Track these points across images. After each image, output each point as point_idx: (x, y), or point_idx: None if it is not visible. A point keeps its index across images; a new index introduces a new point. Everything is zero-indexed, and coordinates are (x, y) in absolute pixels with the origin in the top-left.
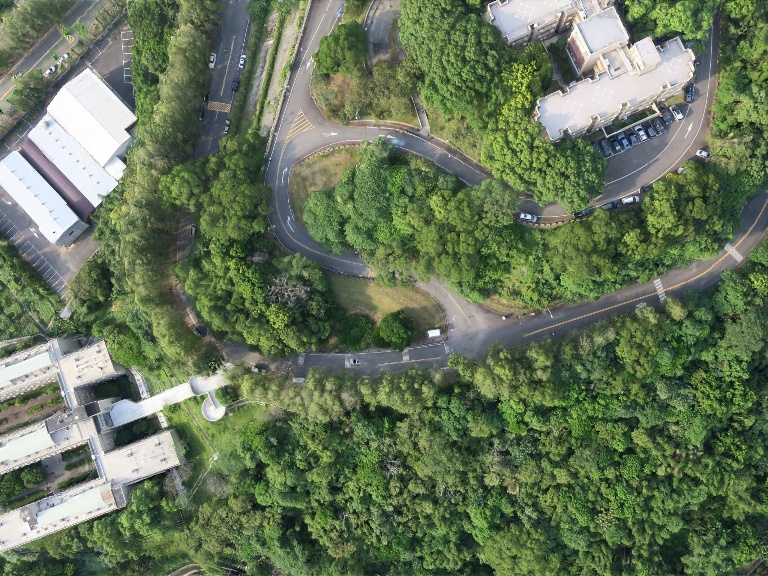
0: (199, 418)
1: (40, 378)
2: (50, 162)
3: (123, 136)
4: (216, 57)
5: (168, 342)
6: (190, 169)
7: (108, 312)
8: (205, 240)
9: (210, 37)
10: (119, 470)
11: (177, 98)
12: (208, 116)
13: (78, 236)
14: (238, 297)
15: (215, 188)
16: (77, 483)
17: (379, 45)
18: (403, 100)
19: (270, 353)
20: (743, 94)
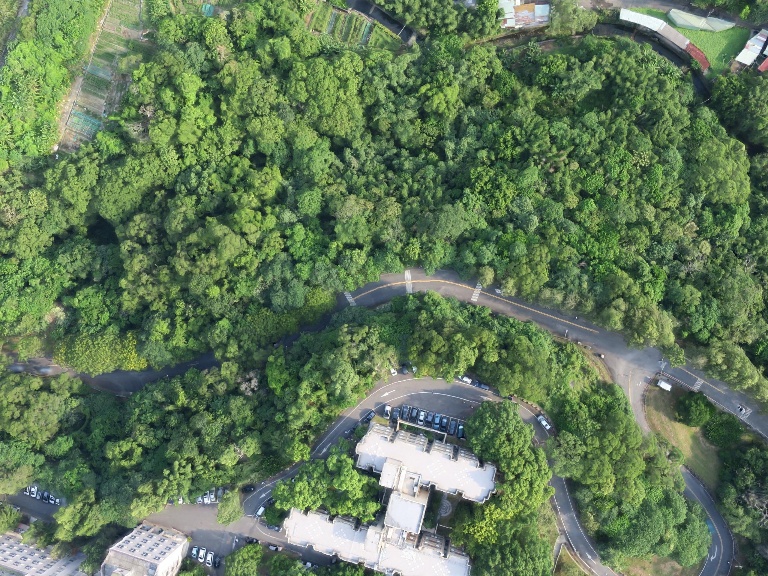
0: None
1: None
2: None
3: None
4: None
5: None
6: None
7: None
8: None
9: None
10: None
11: None
12: None
13: None
14: None
15: None
16: None
17: None
18: None
19: None
20: None
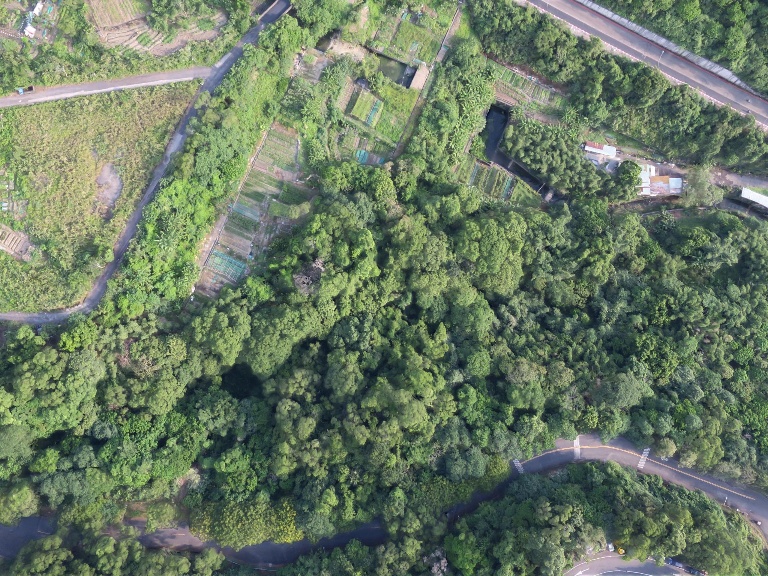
0: None
1: None
2: None
3: None
4: None
5: None
6: None
7: None
8: None
9: None
10: None
11: None
12: None
13: None
14: None
15: None
16: None
17: None
18: None
19: None
20: None
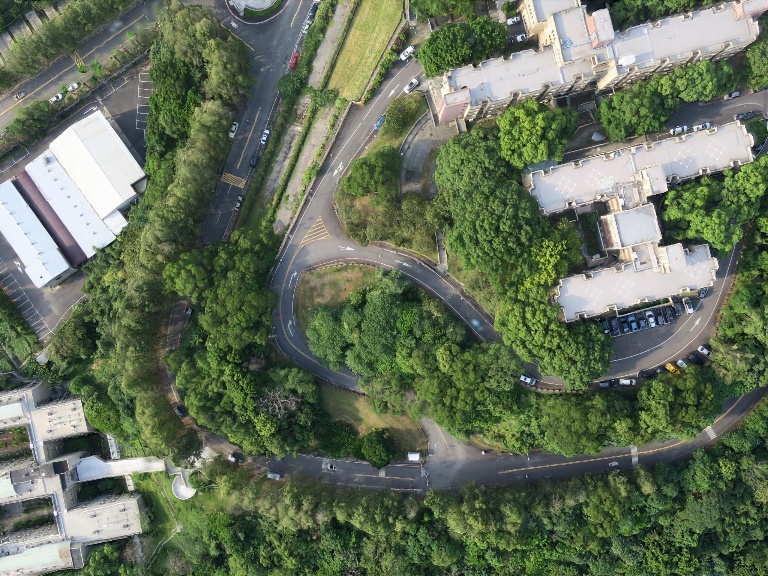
0: (168, 491)
1: (9, 426)
2: (45, 201)
3: (128, 192)
4: (238, 126)
5: (151, 433)
6: (197, 258)
7: (88, 369)
8: (202, 330)
9: (236, 109)
10: (80, 529)
11: (194, 180)
12: (221, 188)
13: (65, 278)
14: (228, 401)
15: (222, 291)
16: (34, 528)
17: (412, 173)
18: (427, 239)
19: (251, 454)
20: (755, 312)
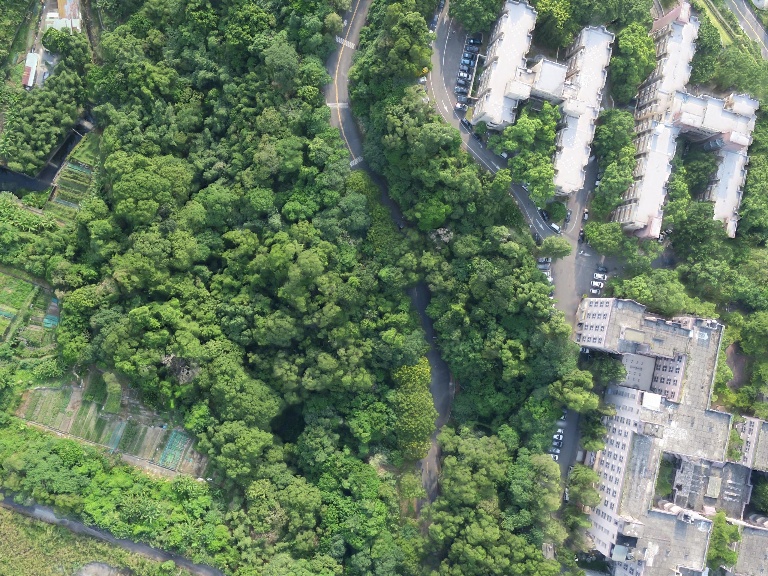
0: None
1: None
2: None
3: None
4: None
5: None
6: None
7: None
8: None
9: None
10: None
11: None
12: None
13: None
14: None
15: None
16: None
17: None
18: None
19: None
20: None
